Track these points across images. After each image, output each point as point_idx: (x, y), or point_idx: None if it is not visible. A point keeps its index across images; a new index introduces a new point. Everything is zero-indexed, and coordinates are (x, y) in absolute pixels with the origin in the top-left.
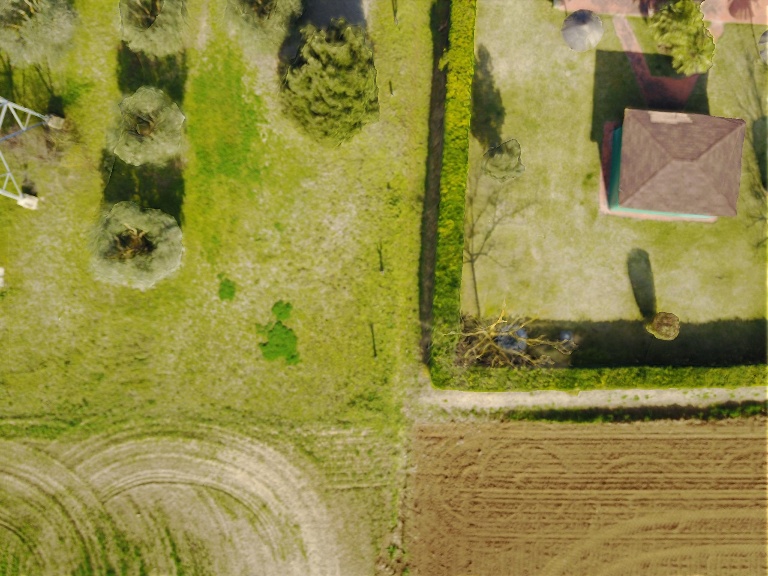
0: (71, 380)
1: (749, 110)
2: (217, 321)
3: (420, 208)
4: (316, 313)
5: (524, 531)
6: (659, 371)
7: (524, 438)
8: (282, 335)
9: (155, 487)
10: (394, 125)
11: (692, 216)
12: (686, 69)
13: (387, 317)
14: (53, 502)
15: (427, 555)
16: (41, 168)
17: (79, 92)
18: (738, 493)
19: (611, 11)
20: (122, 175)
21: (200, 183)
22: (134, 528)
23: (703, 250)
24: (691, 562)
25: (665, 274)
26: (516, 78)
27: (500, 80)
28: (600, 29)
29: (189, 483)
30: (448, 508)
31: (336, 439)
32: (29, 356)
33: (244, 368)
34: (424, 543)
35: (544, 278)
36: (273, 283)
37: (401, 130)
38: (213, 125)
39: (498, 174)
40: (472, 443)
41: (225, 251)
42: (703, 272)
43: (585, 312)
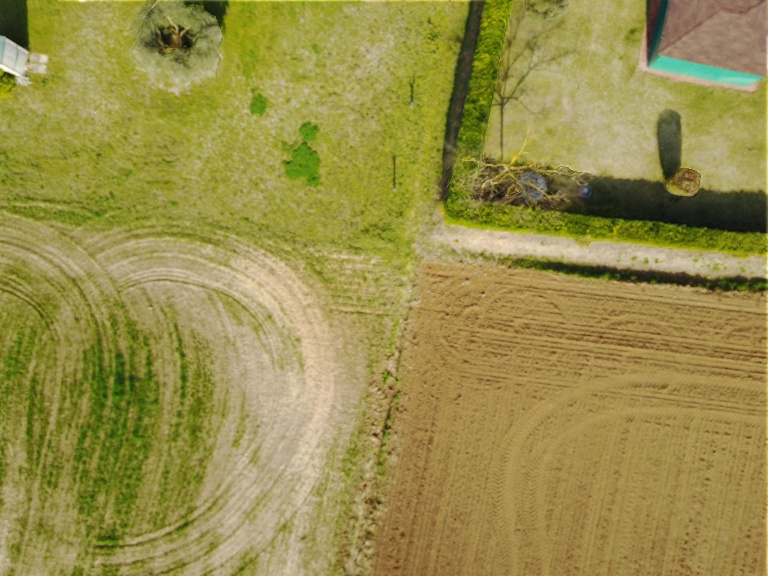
0: (101, 173)
1: None
2: (245, 134)
3: (458, 49)
4: (342, 139)
5: (516, 373)
6: (673, 228)
7: (529, 286)
8: (306, 156)
9: (169, 284)
10: None
11: (731, 78)
12: None
13: (411, 152)
14: (73, 284)
15: (419, 385)
16: None
17: None
18: (732, 363)
19: None
20: None
21: None
22: (145, 319)
23: (737, 119)
24: (675, 423)
25: (694, 139)
26: None
27: None
28: None
29: (201, 285)
30: (445, 343)
31: (346, 263)
32: (64, 144)
33: (266, 183)
34: (417, 373)
35: (571, 129)
36: (304, 104)
37: None
38: None
39: (541, 5)
40: (477, 285)
41: (261, 66)
42: (733, 141)
43: (607, 168)
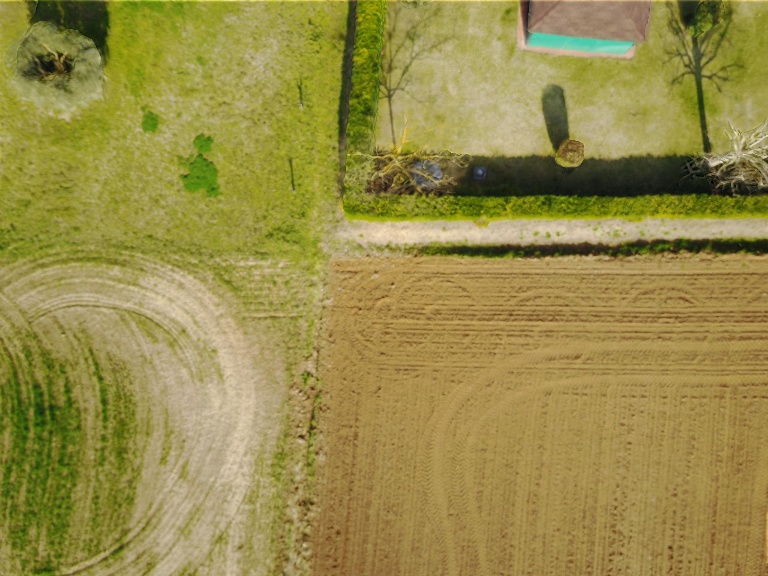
0: None
1: None
2: (140, 152)
3: (342, 47)
4: (236, 147)
5: (432, 360)
6: (564, 200)
7: (436, 272)
8: (203, 167)
9: (79, 310)
10: None
11: (605, 48)
12: None
13: (306, 153)
14: None
15: (339, 382)
16: None
17: None
18: (641, 326)
19: None
20: (48, 6)
21: (124, 16)
22: (59, 347)
23: (618, 86)
24: (592, 391)
25: (579, 110)
26: None
27: None
28: None
29: (112, 307)
30: (361, 338)
31: (254, 270)
32: None
33: (166, 199)
34: (337, 371)
35: (459, 113)
36: (195, 116)
37: None
38: None
39: None
40: (386, 277)
41: (148, 84)
42: (617, 109)
43: (498, 148)
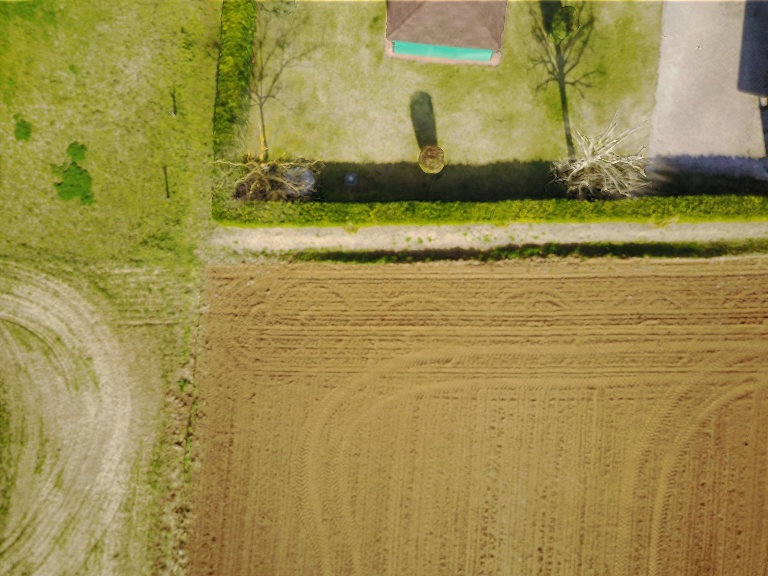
0: None
1: None
2: (13, 161)
3: (216, 55)
4: (110, 155)
5: (306, 365)
6: (427, 205)
7: (310, 278)
8: (76, 175)
9: None
10: None
11: (467, 55)
12: None
13: (180, 160)
14: None
15: (215, 388)
16: None
17: None
18: (511, 330)
19: None
20: None
21: None
22: None
23: (484, 93)
24: (462, 395)
25: (446, 117)
26: None
27: None
28: None
29: None
30: (236, 344)
31: (129, 277)
32: None
33: (40, 207)
34: (213, 377)
35: (329, 120)
36: (68, 125)
37: None
38: None
39: (265, 4)
40: (262, 283)
41: (21, 92)
42: (483, 115)
43: (368, 154)
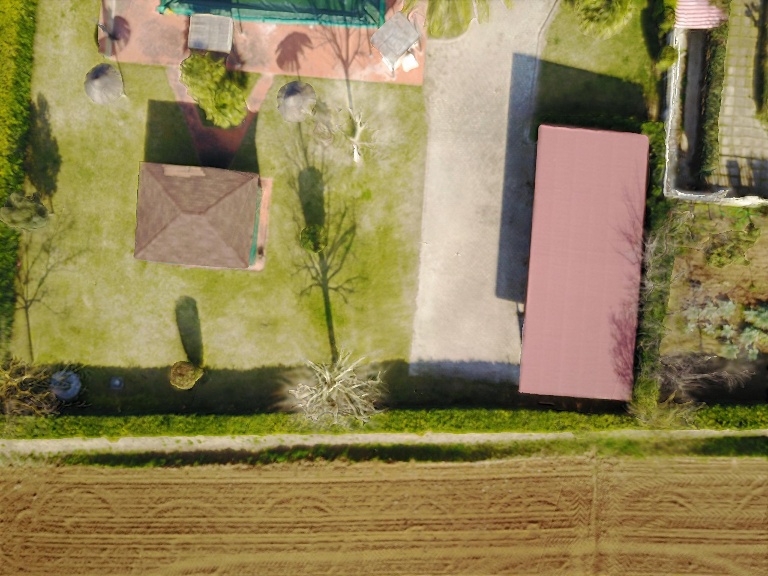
0: None
1: (296, 160)
2: None
3: None
4: None
5: (70, 575)
6: (182, 419)
7: (77, 482)
8: None
9: None
10: None
11: None
12: (218, 121)
13: None
14: None
15: None
16: None
17: None
18: (277, 537)
19: (162, 61)
20: None
21: None
22: None
23: (249, 298)
24: None
25: (212, 321)
26: (72, 126)
27: (57, 128)
28: (117, 83)
29: None
30: (1, 552)
31: None
32: None
33: None
34: None
35: (95, 324)
36: None
37: None
38: None
39: None
40: (29, 487)
41: None
42: (248, 319)
43: (134, 358)
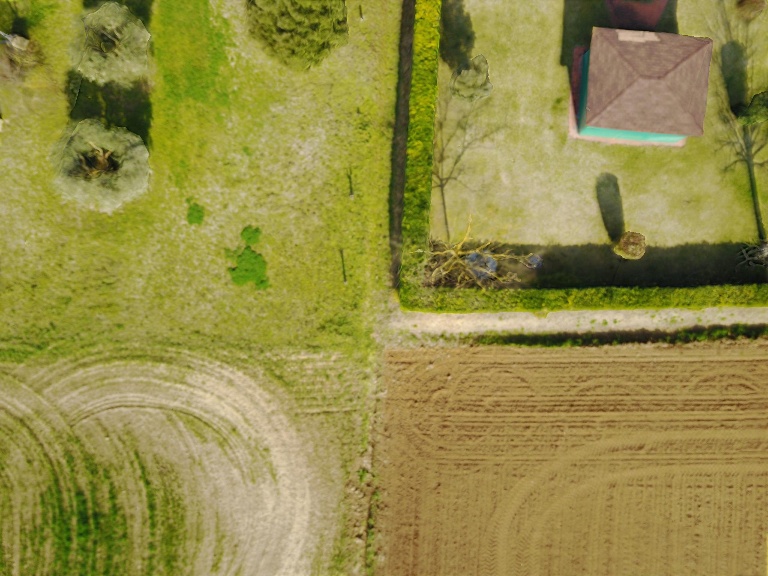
0: (38, 304)
1: (718, 34)
2: (186, 246)
3: (390, 134)
4: (285, 238)
5: (492, 453)
6: (626, 291)
7: (493, 362)
8: (251, 260)
9: (124, 411)
10: (364, 49)
11: (660, 138)
12: None
13: (357, 242)
14: (21, 425)
15: (396, 478)
16: (5, 87)
17: (44, 13)
18: (703, 414)
19: None
20: (89, 98)
21: (168, 107)
22: (103, 451)
23: (671, 174)
24: (656, 482)
25: (633, 198)
26: (486, 1)
27: (470, 3)
28: None
29: (158, 407)
30: (417, 432)
31: (306, 364)
32: None
33: (213, 293)
34: (393, 466)
35: (513, 202)
36: (242, 208)
37: (371, 54)
38: (181, 48)
39: (466, 91)
40: (442, 368)
41: (194, 175)
42: (671, 196)
43: (554, 236)
